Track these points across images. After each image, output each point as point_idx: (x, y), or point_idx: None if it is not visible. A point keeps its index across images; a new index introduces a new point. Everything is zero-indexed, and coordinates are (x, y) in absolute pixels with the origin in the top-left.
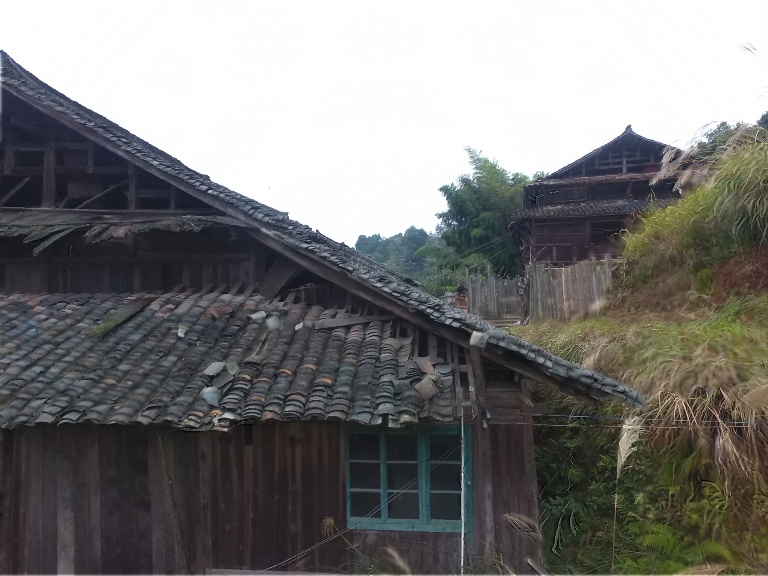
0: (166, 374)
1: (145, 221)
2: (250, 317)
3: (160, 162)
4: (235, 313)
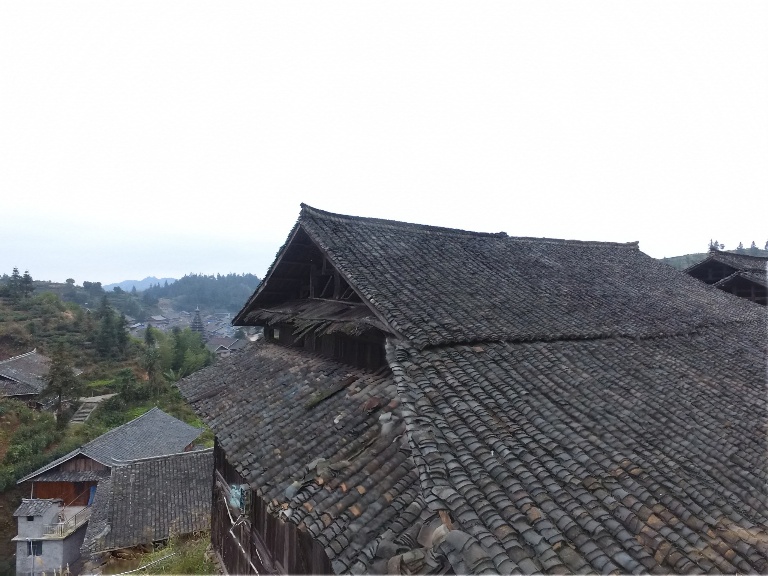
0: (300, 456)
1: (344, 321)
2: (379, 417)
3: (352, 275)
4: (379, 408)
